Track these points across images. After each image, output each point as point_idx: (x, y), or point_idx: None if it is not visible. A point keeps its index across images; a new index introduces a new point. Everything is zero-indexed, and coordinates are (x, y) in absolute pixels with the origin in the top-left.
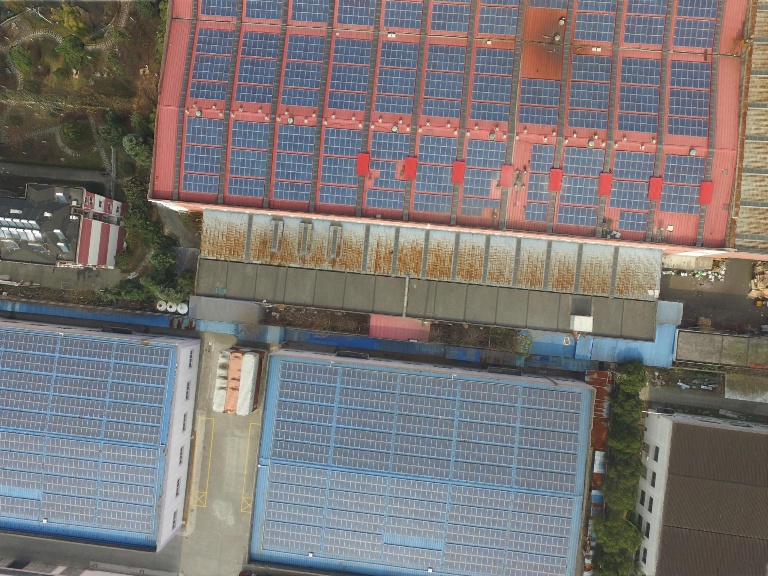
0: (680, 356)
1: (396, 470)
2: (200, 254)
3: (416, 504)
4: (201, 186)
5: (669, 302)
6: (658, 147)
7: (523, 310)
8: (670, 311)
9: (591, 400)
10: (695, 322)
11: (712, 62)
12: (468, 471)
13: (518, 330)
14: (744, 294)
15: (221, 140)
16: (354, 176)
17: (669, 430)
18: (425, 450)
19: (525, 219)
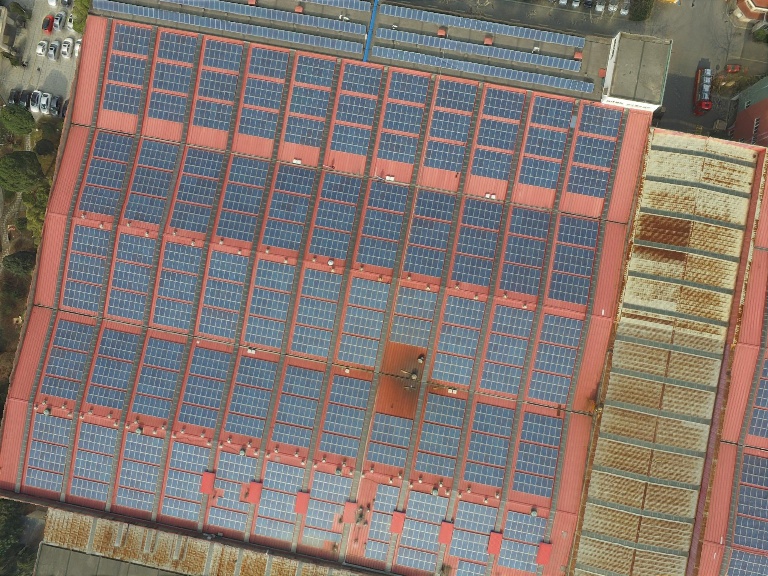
0: None
1: None
2: (43, 539)
3: None
4: (44, 483)
5: None
6: (501, 502)
7: None
8: None
9: None
10: None
11: (564, 419)
12: None
13: None
14: None
15: (68, 440)
16: (199, 492)
17: None
18: None
19: (365, 556)
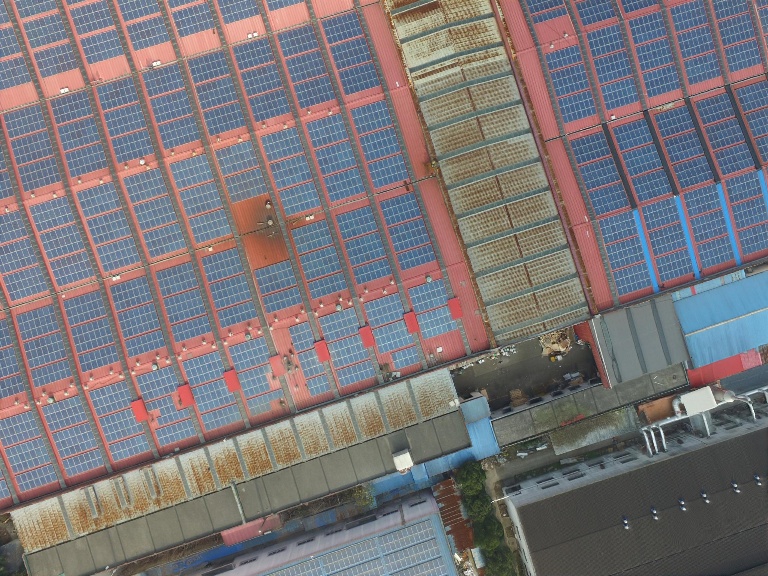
0: (502, 443)
1: None
2: (24, 551)
3: None
4: None
5: (473, 401)
6: (398, 286)
7: (349, 468)
8: (477, 408)
9: (440, 521)
10: (508, 397)
11: (414, 190)
12: None
13: None
14: (538, 355)
15: None
16: (137, 424)
17: (516, 515)
18: None
19: (311, 395)
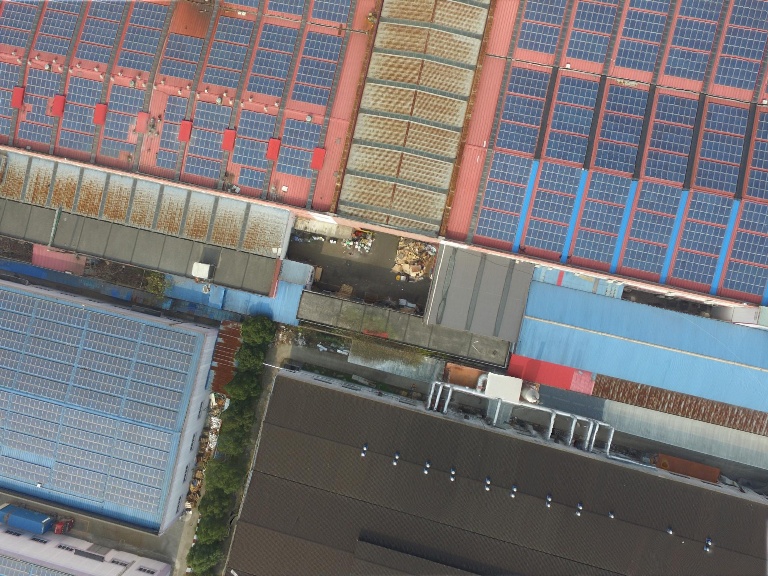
0: (301, 315)
1: (18, 387)
2: None
3: (32, 421)
4: None
5: (298, 263)
6: (280, 110)
7: (158, 253)
8: (297, 271)
9: None
10: (339, 288)
11: (344, 37)
12: (82, 396)
13: (160, 273)
14: (389, 268)
15: None
16: (10, 108)
17: (273, 382)
18: (48, 372)
19: (156, 165)
